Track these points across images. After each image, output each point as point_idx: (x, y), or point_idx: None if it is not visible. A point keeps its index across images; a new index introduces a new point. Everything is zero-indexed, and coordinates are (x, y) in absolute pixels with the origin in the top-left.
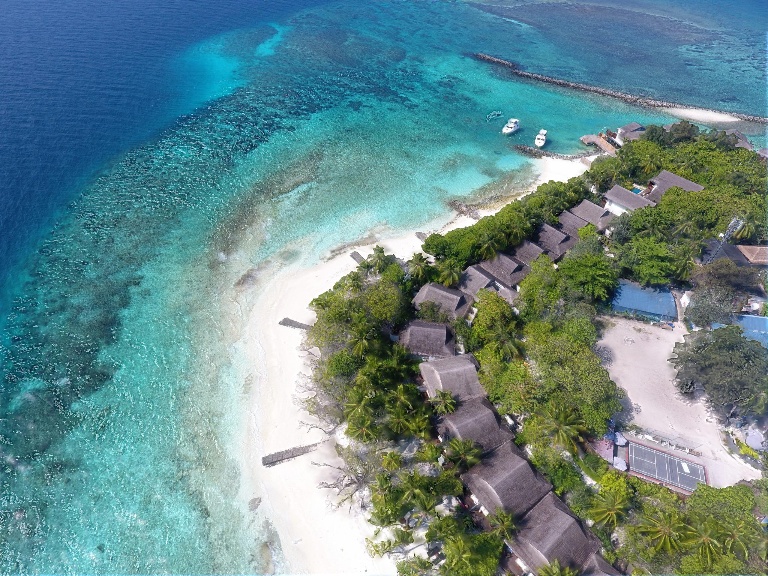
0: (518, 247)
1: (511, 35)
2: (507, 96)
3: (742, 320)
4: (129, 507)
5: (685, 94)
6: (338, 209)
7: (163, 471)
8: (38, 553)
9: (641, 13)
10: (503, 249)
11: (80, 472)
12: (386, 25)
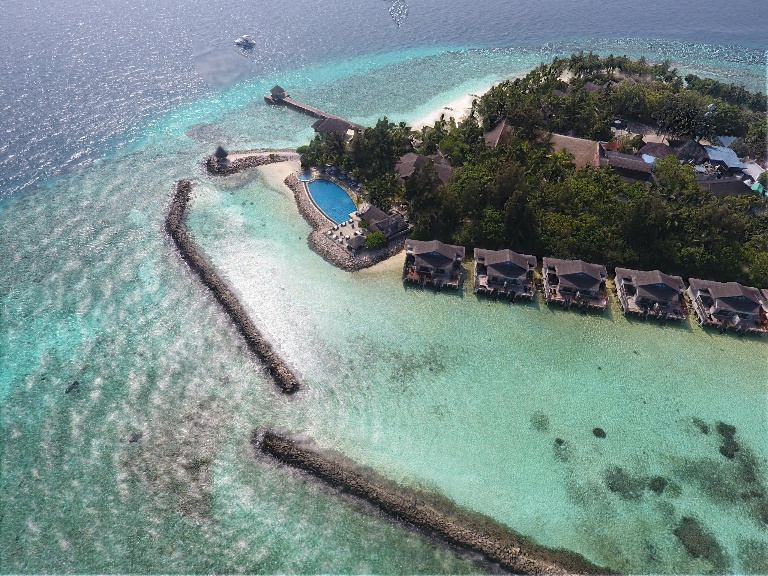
0: None
1: None
2: None
3: (751, 164)
4: (522, 60)
5: None
6: None
7: None
8: None
9: None
10: (717, 97)
11: (526, 54)
12: None
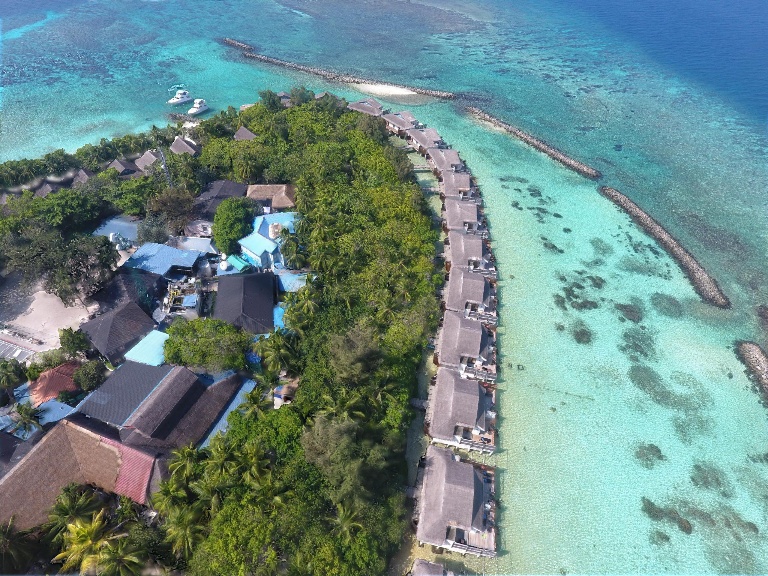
0: (38, 189)
1: (281, 24)
2: (215, 74)
3: (186, 241)
4: None
5: (391, 73)
6: None
7: None
8: None
9: (432, 7)
10: (9, 188)
11: None
12: (165, 14)
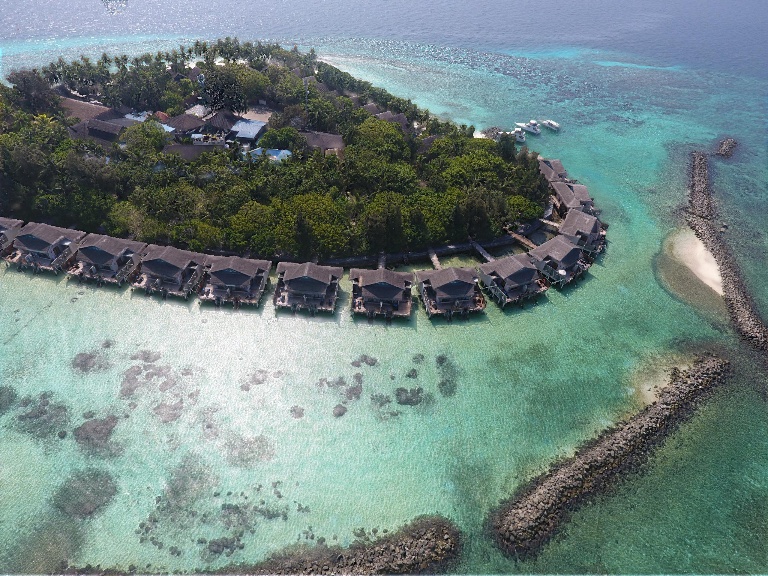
0: None
1: None
2: (618, 142)
3: None
4: None
5: None
6: (381, 75)
7: None
8: None
9: None
10: None
11: None
12: (766, 107)
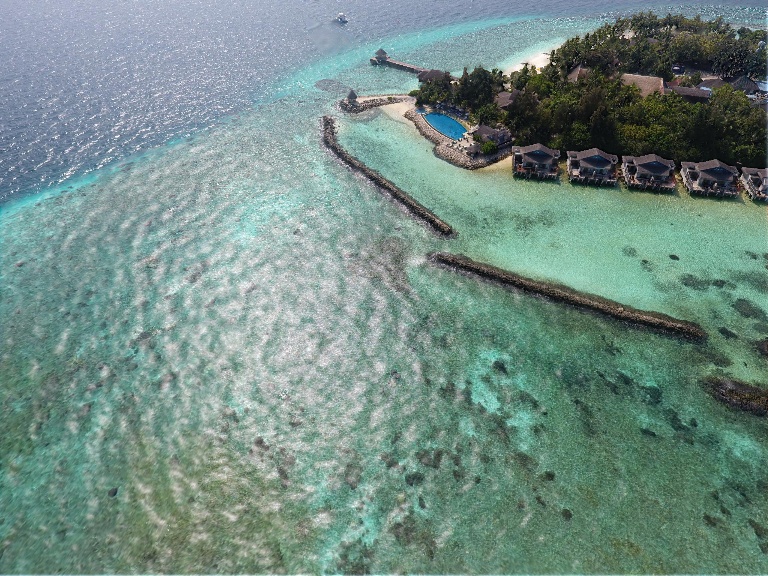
0: None
1: None
2: None
3: None
4: None
5: None
6: None
7: (596, 27)
8: (566, 21)
9: None
10: None
11: None
12: None
